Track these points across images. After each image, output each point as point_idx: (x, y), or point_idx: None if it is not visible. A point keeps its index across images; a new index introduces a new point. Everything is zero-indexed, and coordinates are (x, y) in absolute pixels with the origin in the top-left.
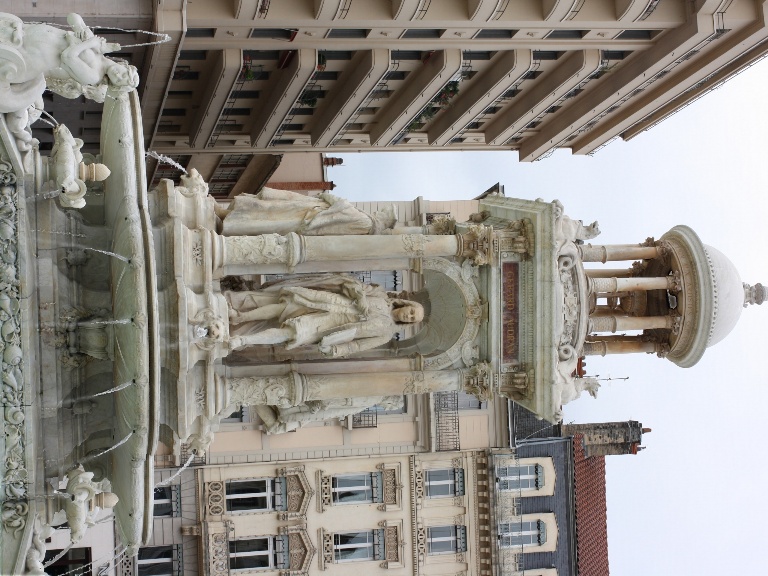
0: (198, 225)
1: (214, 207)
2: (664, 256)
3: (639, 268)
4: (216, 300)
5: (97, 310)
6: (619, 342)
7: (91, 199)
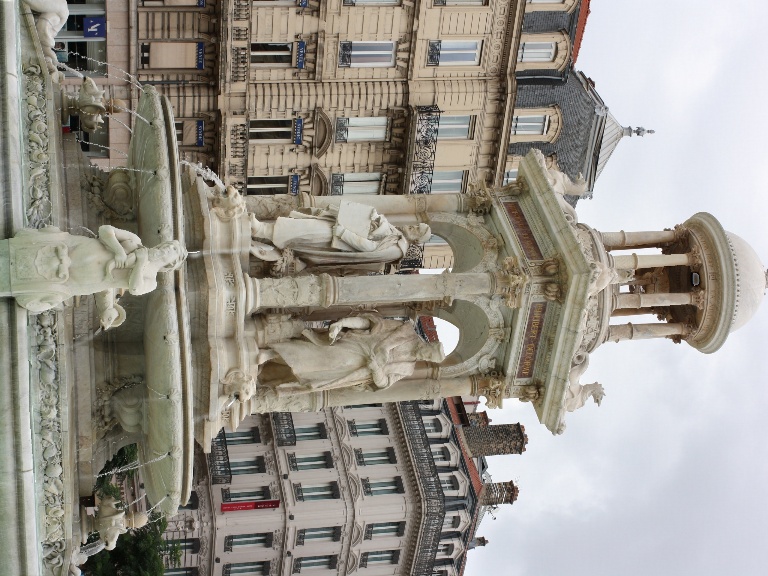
0: None
1: None
2: None
3: (694, 268)
4: None
5: None
6: None
7: None
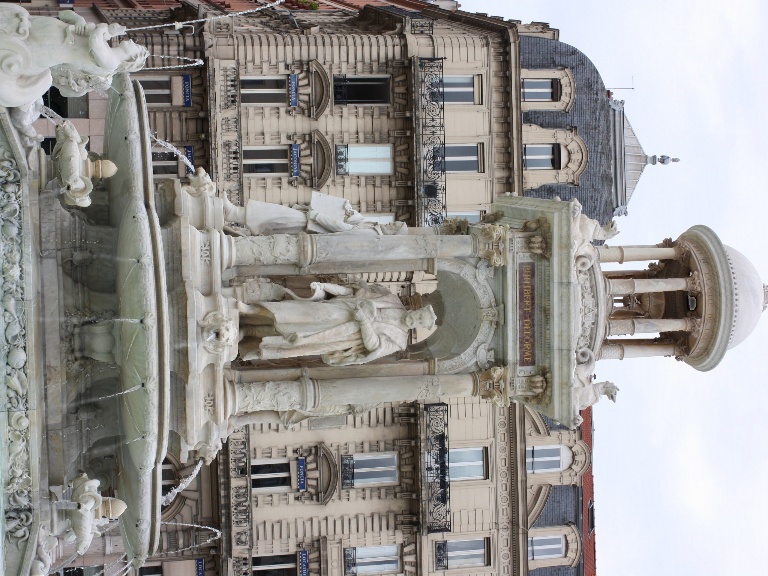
0: (216, 367)
1: (241, 312)
2: None
3: (683, 261)
4: (217, 434)
5: (102, 457)
6: (612, 319)
7: (105, 373)
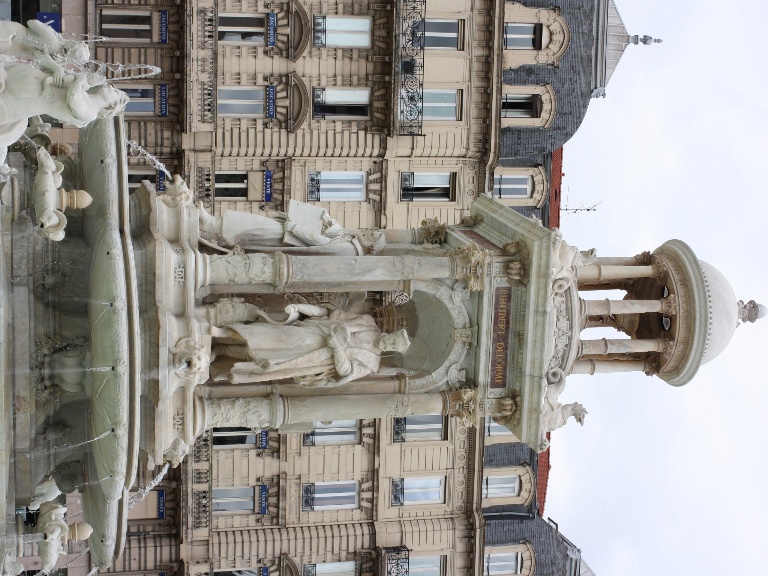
0: None
1: None
2: (661, 352)
3: (661, 280)
4: None
5: None
6: None
7: None
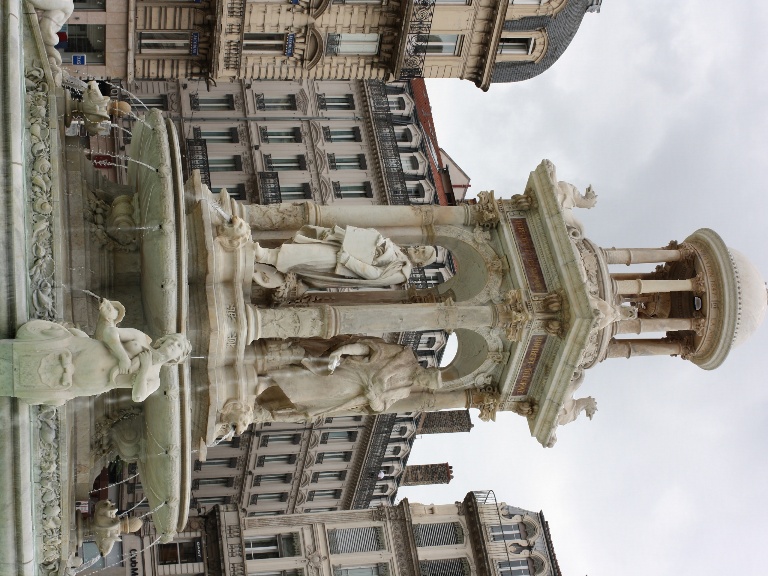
0: None
1: None
2: None
3: (697, 294)
4: None
5: None
6: None
7: None
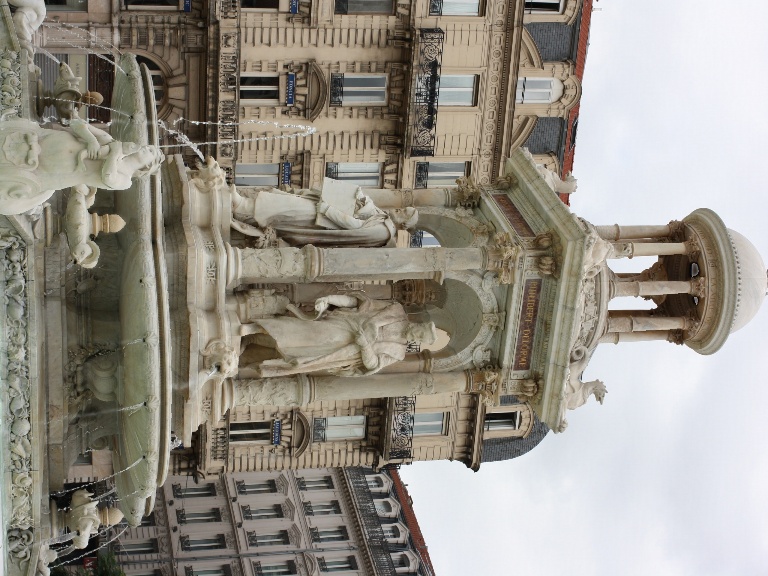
0: None
1: None
2: None
3: (692, 257)
4: None
5: None
6: None
7: None
